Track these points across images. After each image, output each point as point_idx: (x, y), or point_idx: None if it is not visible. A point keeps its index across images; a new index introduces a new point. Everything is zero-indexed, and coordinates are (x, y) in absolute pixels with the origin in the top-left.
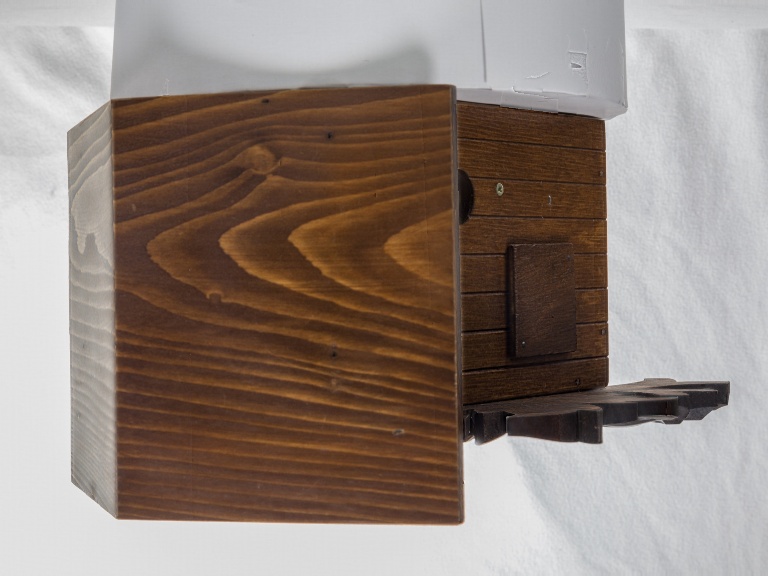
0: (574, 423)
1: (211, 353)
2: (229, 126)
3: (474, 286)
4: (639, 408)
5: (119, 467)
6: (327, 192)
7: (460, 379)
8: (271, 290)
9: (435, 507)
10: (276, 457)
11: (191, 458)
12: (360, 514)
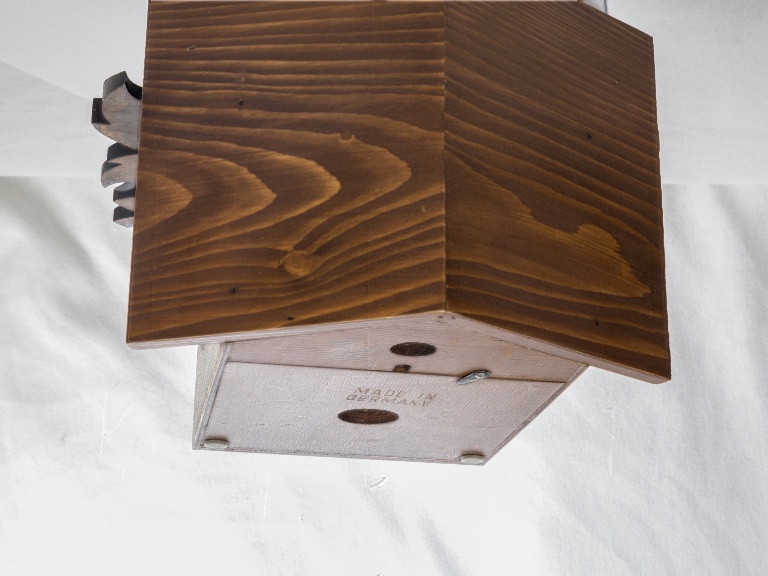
0: None
1: (352, 88)
2: (327, 293)
3: None
4: None
5: None
6: (239, 240)
7: None
8: (294, 149)
9: None
10: (296, 11)
11: None
12: None
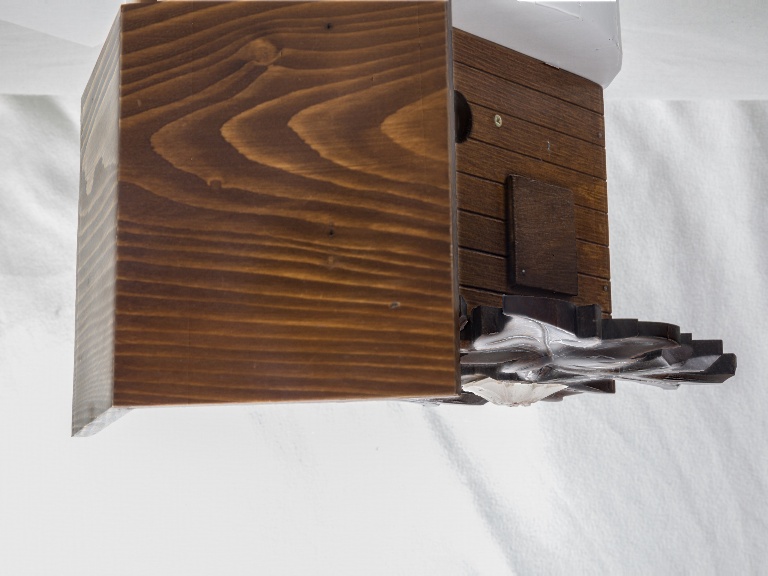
0: (572, 314)
1: (210, 237)
2: (233, 22)
3: (473, 206)
4: (640, 328)
5: (116, 354)
6: (326, 78)
7: (456, 253)
8: (270, 174)
9: (431, 378)
10: (272, 336)
11: (188, 341)
12: (356, 389)
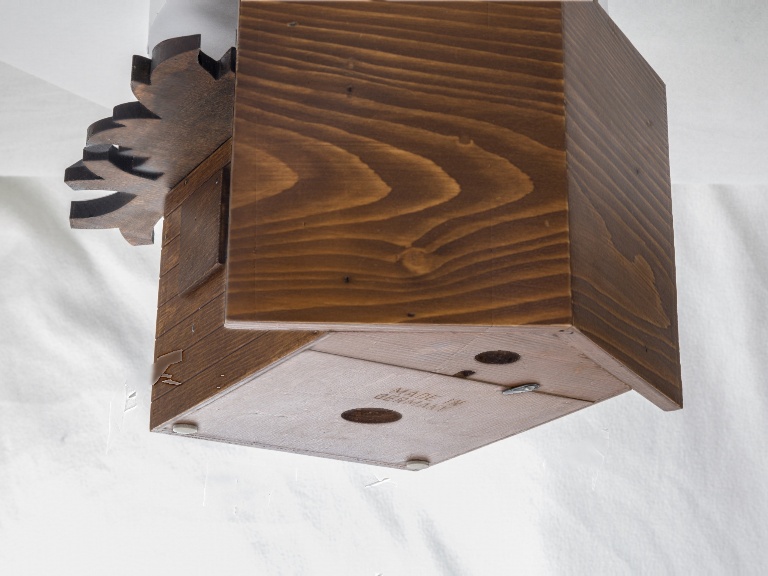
0: None
1: (469, 93)
2: (449, 294)
3: None
4: (114, 123)
5: None
6: (352, 229)
7: None
8: (409, 145)
9: None
10: (408, 6)
11: (489, 6)
12: None
